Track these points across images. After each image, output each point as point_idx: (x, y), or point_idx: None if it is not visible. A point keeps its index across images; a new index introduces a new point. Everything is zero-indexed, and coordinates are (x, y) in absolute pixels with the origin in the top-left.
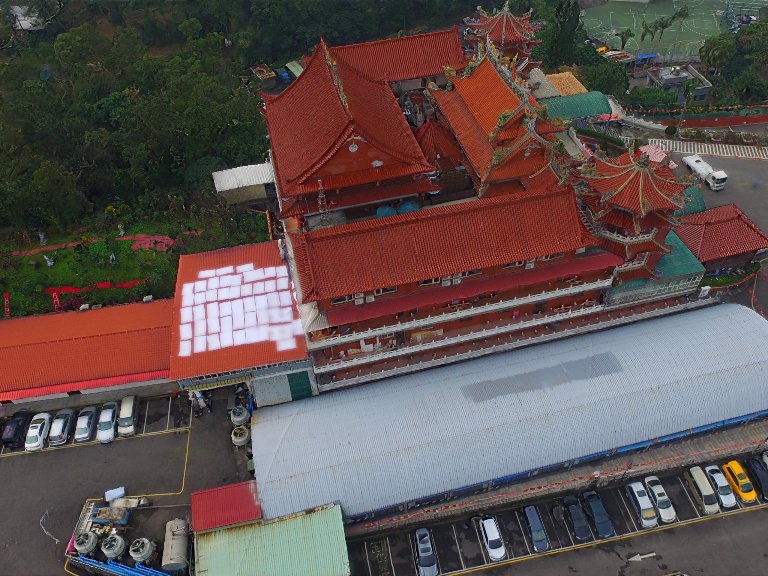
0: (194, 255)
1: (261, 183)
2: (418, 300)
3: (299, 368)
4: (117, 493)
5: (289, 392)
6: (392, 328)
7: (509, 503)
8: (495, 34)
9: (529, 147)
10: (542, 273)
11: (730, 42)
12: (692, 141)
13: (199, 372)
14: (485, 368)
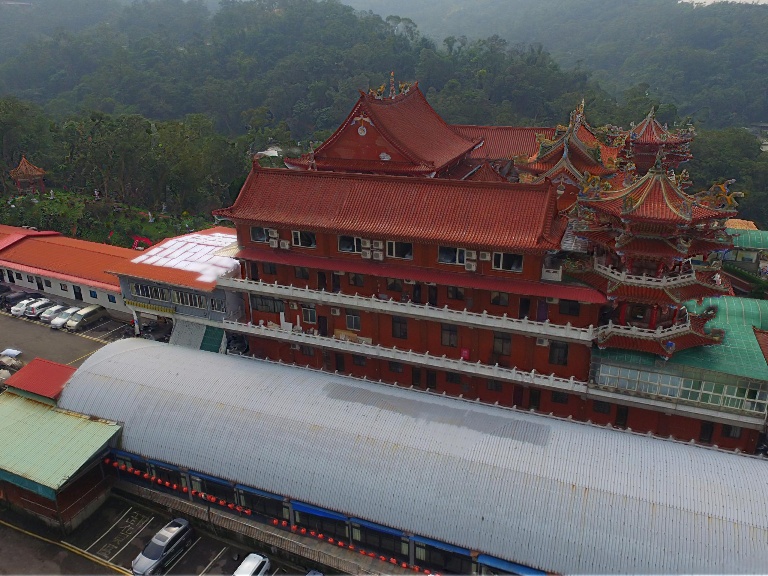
0: (229, 228)
1: None
2: (331, 263)
3: (217, 320)
4: (12, 352)
5: (200, 345)
6: (299, 292)
7: (304, 560)
8: None
9: (562, 182)
10: (485, 282)
11: None
12: None
13: (128, 272)
14: (380, 385)
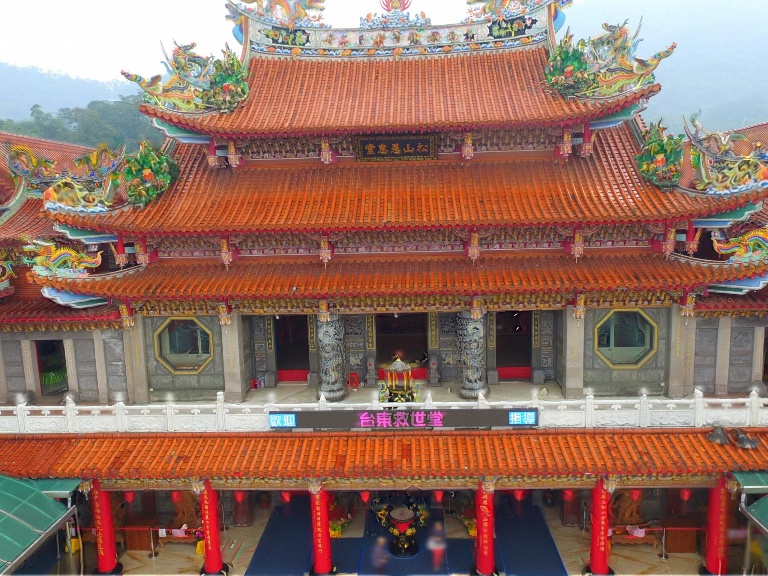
0: None
1: None
2: None
3: None
4: None
5: None
6: None
7: None
8: None
9: None
10: None
11: None
12: None
13: None
14: None
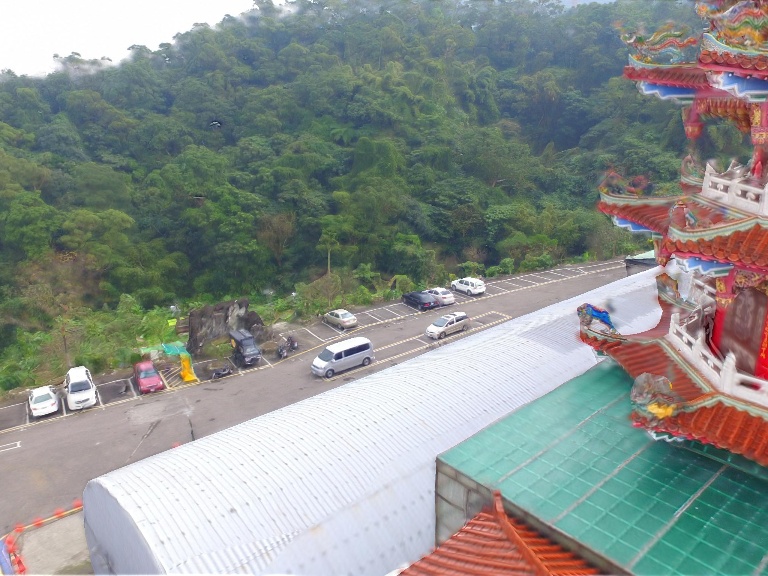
0: None
1: None
2: None
3: None
4: None
5: None
6: None
7: None
8: None
9: None
10: None
11: None
12: None
13: None
14: None
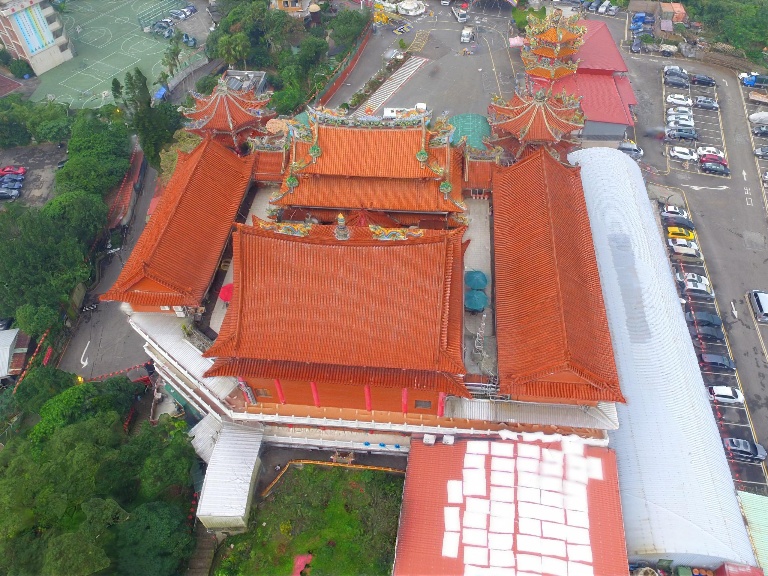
0: (400, 561)
1: (258, 451)
2: None
3: None
4: None
5: None
6: None
7: None
8: (239, 117)
9: None
10: None
11: (241, 34)
12: (361, 105)
13: None
14: None
